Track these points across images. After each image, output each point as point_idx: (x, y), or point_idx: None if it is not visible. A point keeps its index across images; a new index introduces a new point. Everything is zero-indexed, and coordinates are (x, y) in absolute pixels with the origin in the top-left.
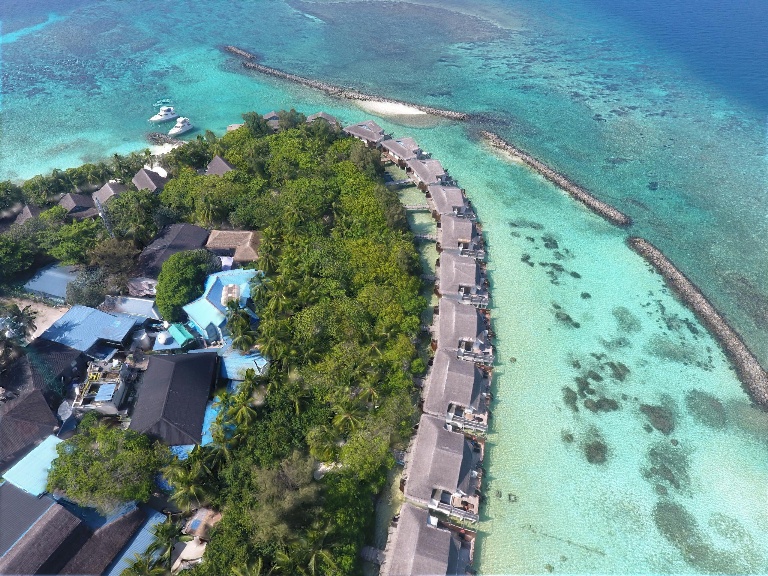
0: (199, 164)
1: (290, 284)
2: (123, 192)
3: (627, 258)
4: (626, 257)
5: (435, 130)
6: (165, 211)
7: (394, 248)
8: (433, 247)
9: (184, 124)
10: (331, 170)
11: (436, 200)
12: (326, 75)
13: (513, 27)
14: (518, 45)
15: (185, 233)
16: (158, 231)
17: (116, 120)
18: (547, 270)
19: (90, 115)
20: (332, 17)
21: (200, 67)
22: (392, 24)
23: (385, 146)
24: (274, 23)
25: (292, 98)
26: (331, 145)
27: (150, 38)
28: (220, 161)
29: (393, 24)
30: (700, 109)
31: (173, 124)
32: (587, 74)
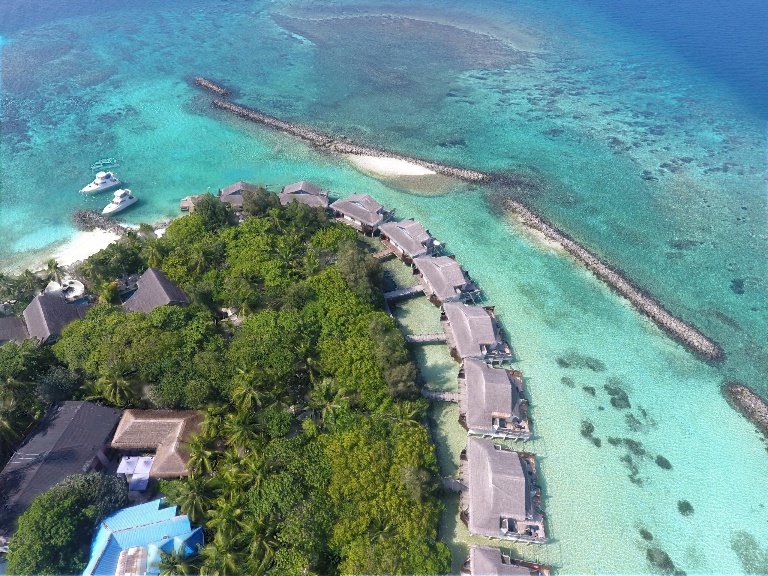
0: (132, 269)
1: (225, 568)
2: (6, 335)
3: (731, 425)
4: (729, 423)
5: (448, 199)
6: (56, 379)
7: (398, 446)
8: (454, 412)
9: (124, 198)
10: (309, 290)
11: (456, 331)
12: (313, 117)
13: (530, 49)
14: (538, 72)
15: (80, 423)
16: (46, 408)
17: (40, 189)
18: (621, 454)
19: (8, 182)
20: (323, 37)
21: (160, 107)
22: (392, 46)
23: (384, 233)
24: (256, 46)
25: (269, 152)
26: (312, 236)
27: (107, 67)
28: (153, 278)
29: (393, 46)
30: (767, 161)
31: (113, 194)
32: (624, 112)
